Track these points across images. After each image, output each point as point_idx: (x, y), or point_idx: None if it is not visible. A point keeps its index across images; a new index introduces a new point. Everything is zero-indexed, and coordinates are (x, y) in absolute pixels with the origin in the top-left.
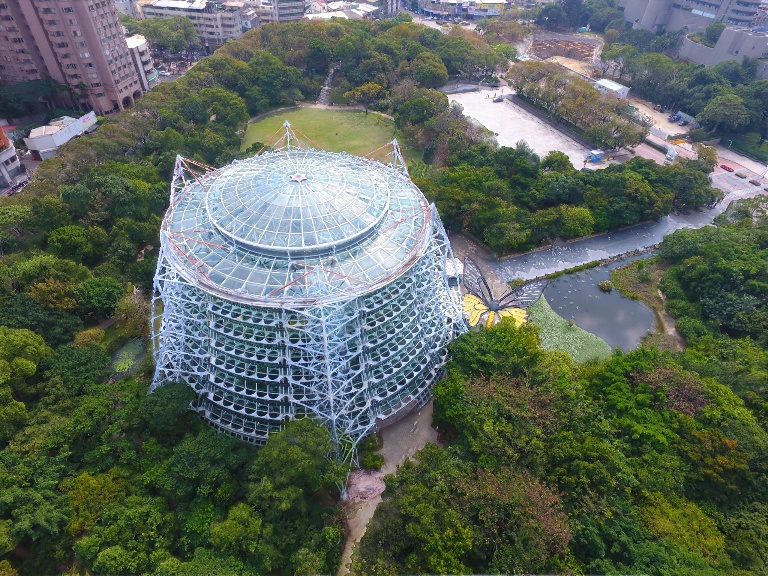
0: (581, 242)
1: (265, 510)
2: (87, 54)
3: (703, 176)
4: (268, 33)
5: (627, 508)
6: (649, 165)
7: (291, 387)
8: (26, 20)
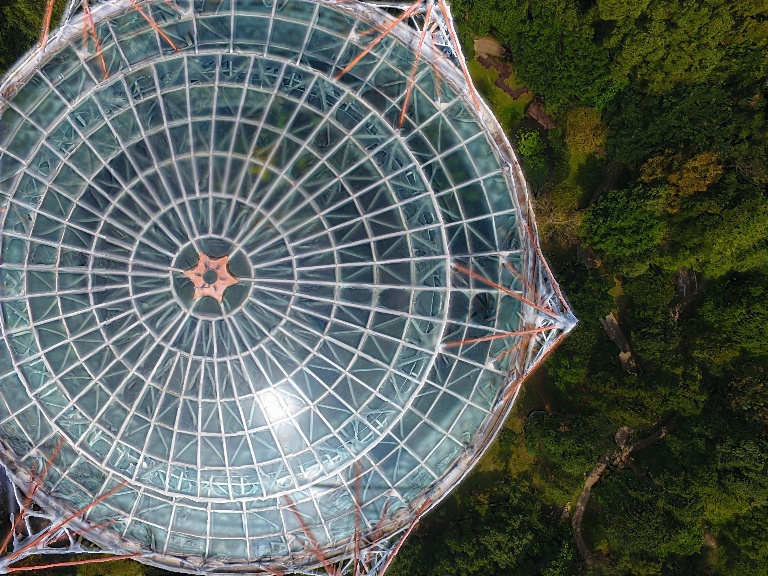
0: None
1: None
2: None
3: None
4: None
5: None
6: None
7: None
8: None
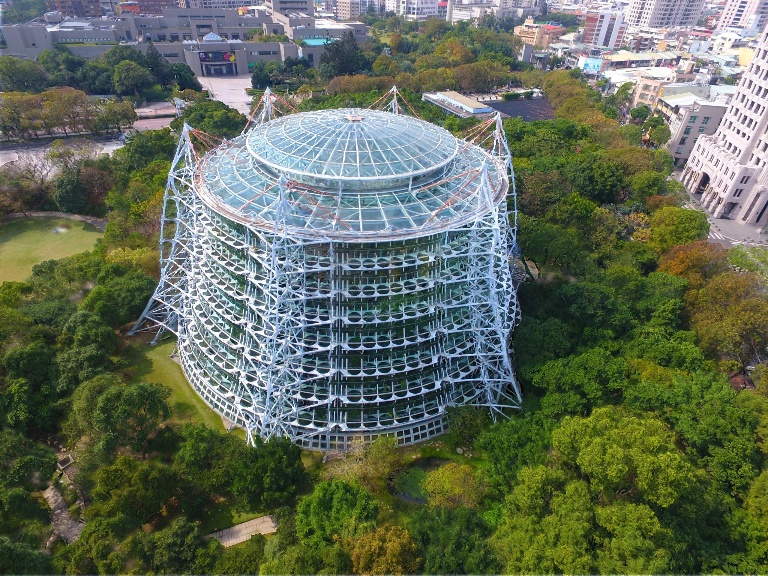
0: None
1: None
2: None
3: None
4: None
5: None
6: None
7: None
8: None
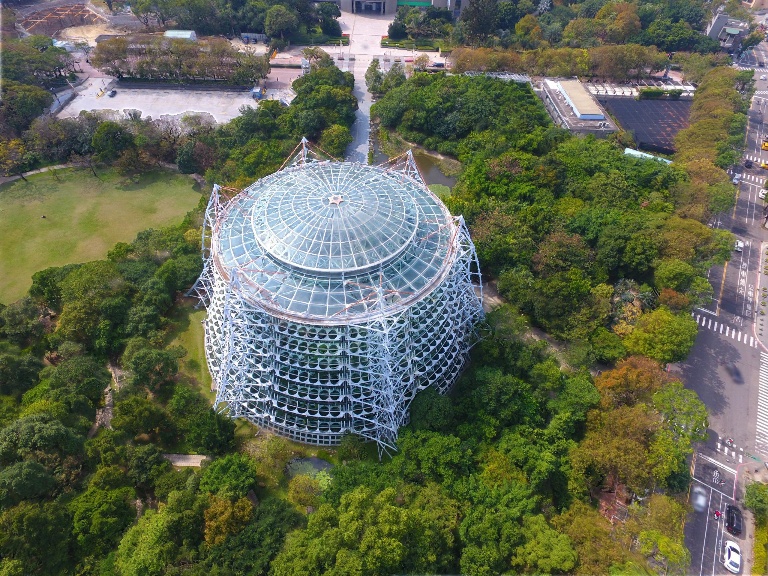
0: (346, 149)
1: None
2: None
3: None
4: None
5: None
6: (318, 76)
7: None
8: None
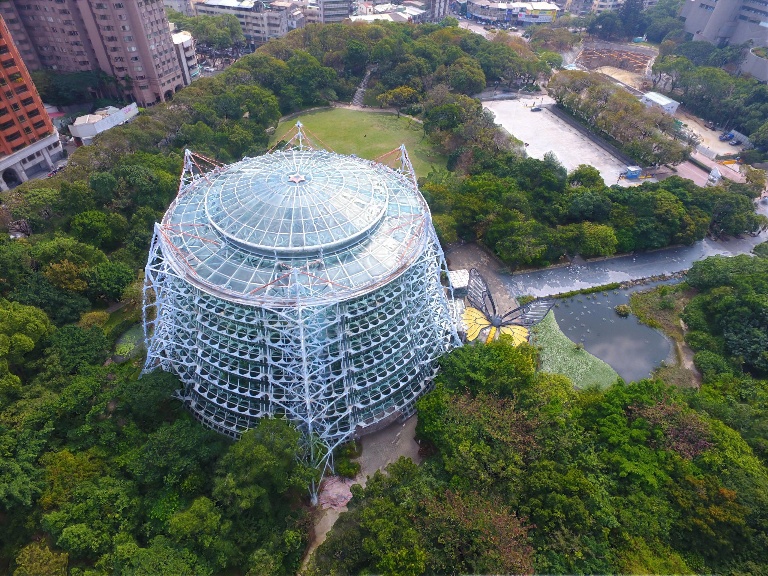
0: (603, 262)
1: (227, 506)
2: (134, 48)
3: (747, 201)
4: (310, 33)
5: (601, 550)
6: (686, 185)
7: (271, 386)
8: (81, 14)
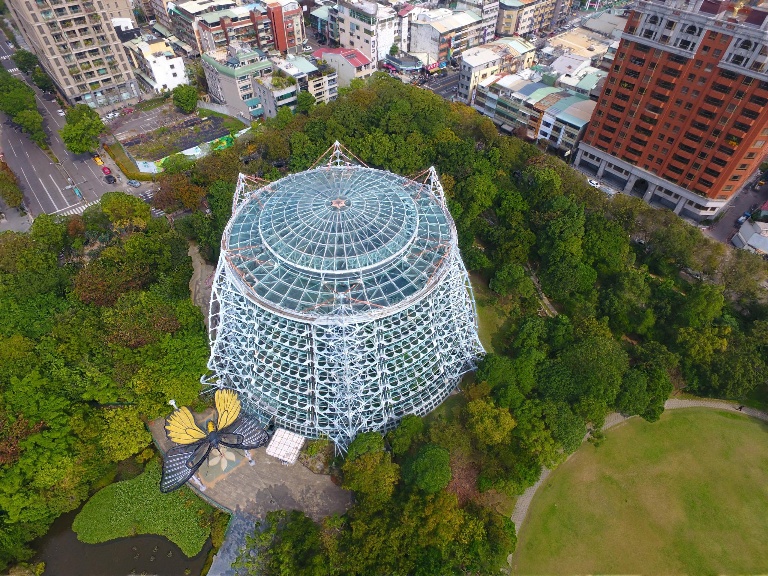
0: None
1: None
2: None
3: None
4: None
5: None
6: None
7: None
8: None
